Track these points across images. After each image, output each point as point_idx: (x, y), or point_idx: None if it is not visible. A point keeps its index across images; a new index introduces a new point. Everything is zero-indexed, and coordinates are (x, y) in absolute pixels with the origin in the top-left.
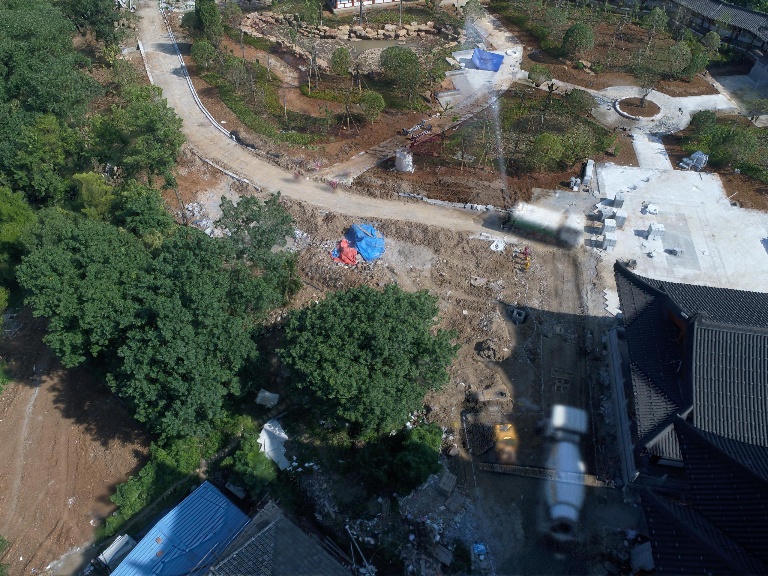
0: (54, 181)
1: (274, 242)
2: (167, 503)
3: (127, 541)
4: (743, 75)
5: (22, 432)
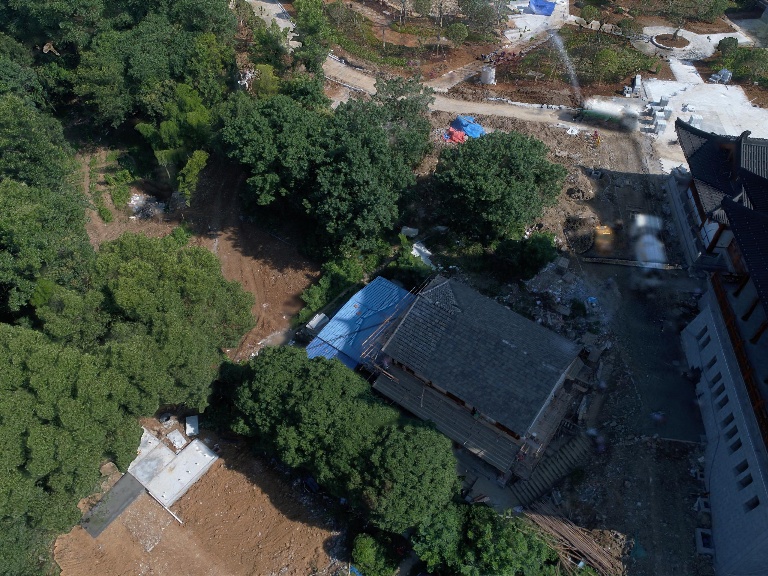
0: (215, 85)
1: (421, 107)
2: (344, 299)
3: (325, 316)
4: (756, 19)
5: None
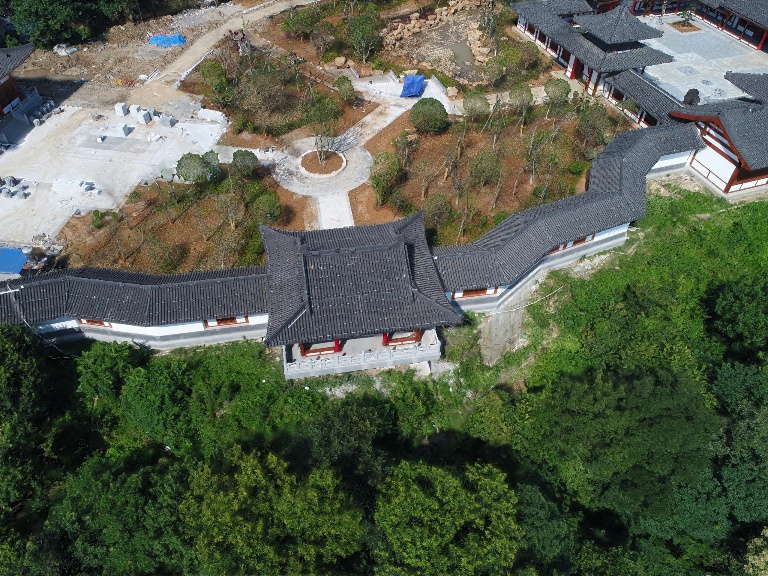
0: None
1: None
2: None
3: None
4: None
5: None
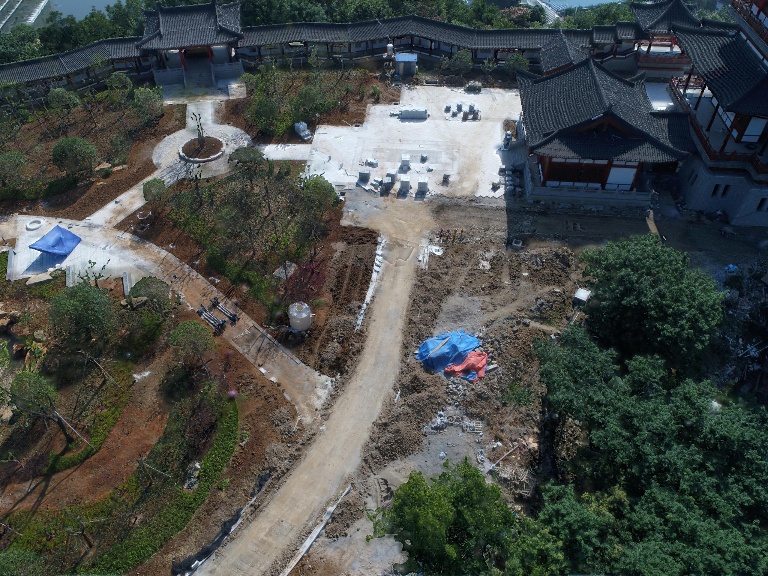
0: None
1: (596, 347)
2: None
3: None
4: (156, 88)
5: None
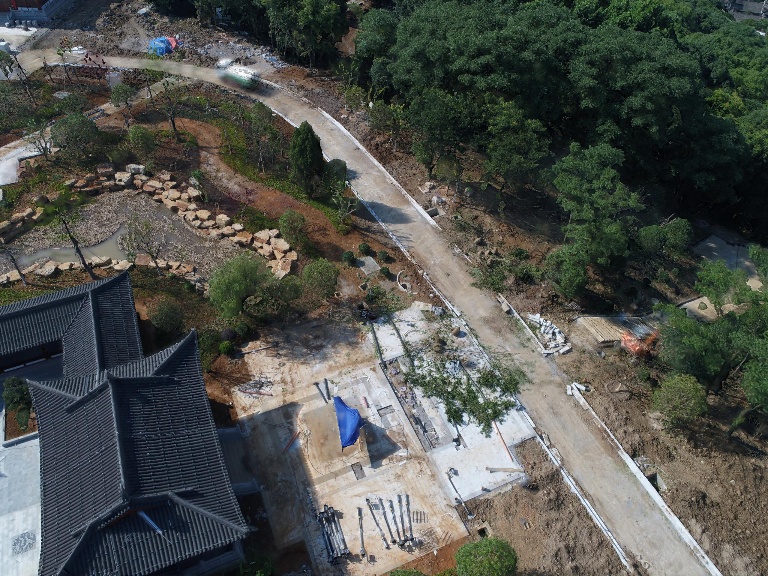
0: None
1: None
2: None
3: None
4: None
5: (346, 43)
